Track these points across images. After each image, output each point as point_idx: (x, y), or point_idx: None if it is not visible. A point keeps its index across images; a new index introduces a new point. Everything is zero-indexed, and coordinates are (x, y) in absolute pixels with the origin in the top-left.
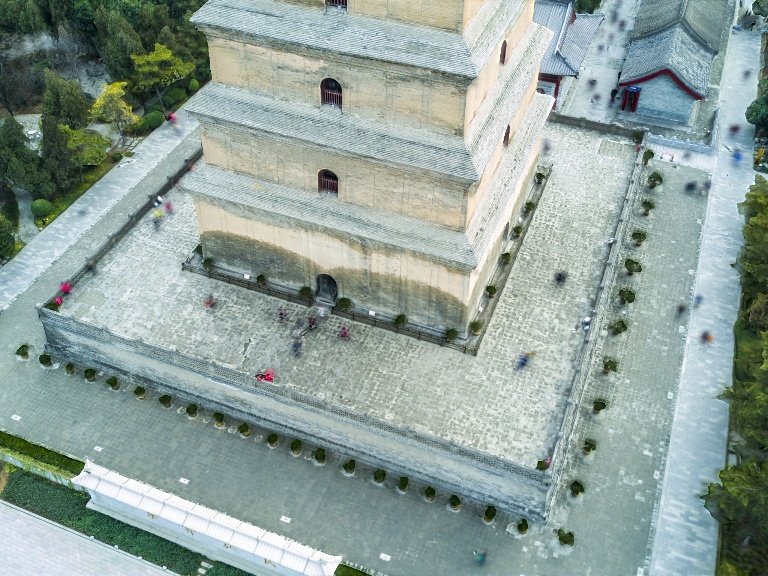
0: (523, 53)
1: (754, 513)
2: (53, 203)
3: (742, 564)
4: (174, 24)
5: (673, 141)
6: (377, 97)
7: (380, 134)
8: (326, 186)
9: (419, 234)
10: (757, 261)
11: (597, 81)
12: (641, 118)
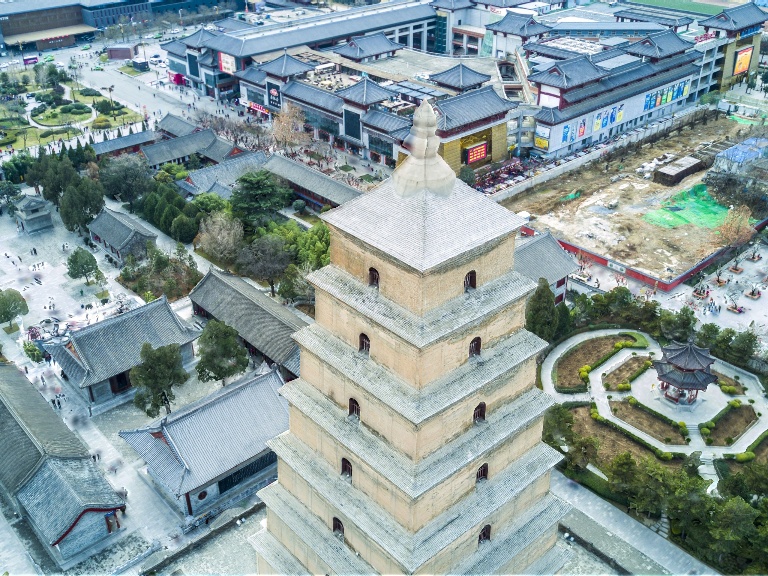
0: None
1: (735, 540)
2: None
3: (732, 569)
4: None
5: None
6: None
7: (517, 532)
8: None
9: (541, 569)
10: (548, 438)
11: None
12: None
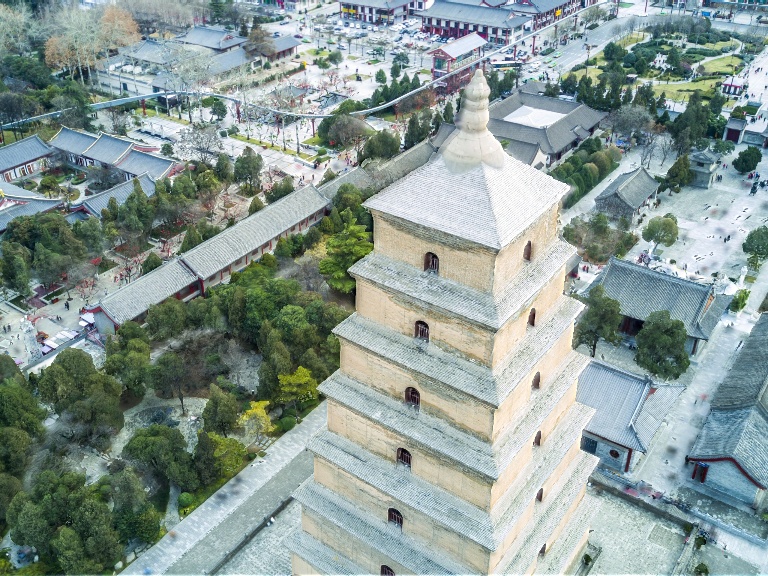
0: (564, 485)
1: None
2: (196, 494)
3: None
4: (319, 341)
5: (730, 527)
6: (427, 532)
7: (427, 558)
8: (387, 574)
9: None
10: None
11: (677, 439)
12: (709, 490)
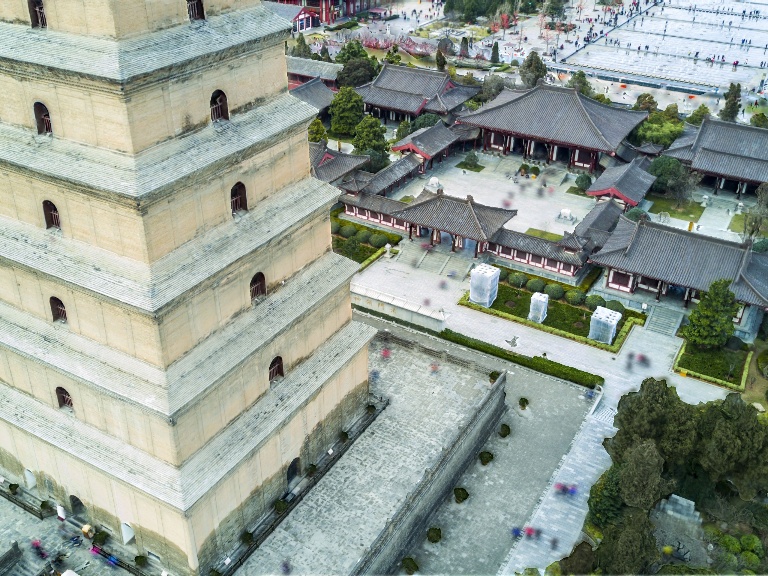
0: None
1: None
2: None
3: None
4: None
5: None
6: None
7: None
8: None
9: None
10: None
11: None
12: None
